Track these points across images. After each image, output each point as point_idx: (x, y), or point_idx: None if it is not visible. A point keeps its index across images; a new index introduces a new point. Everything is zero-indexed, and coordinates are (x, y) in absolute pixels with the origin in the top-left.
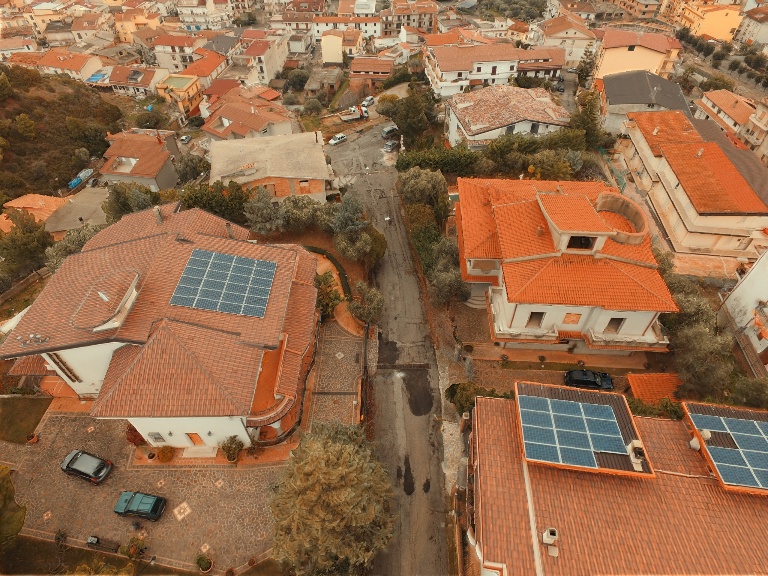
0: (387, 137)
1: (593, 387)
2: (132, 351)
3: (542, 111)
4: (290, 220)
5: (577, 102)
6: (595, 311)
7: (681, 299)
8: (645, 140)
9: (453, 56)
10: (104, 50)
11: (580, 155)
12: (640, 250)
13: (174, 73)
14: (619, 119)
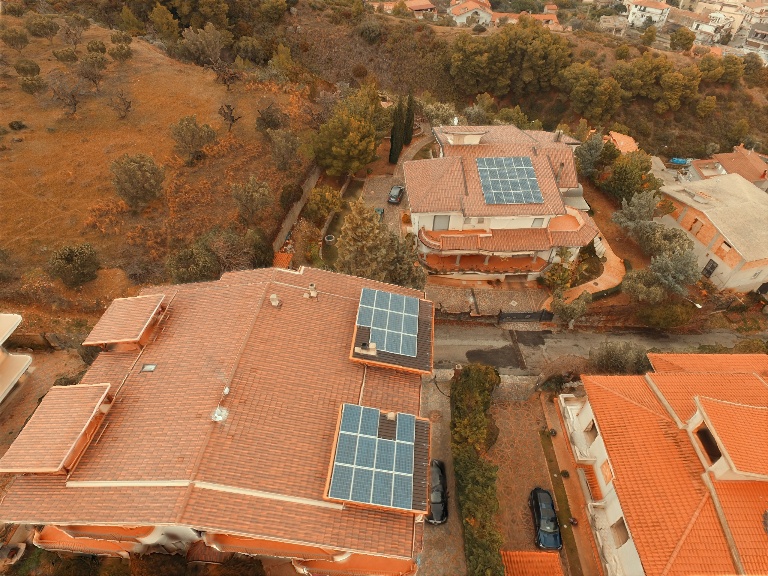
0: None
1: (536, 519)
2: None
3: None
4: (644, 235)
5: None
6: None
7: None
8: None
9: None
10: None
11: None
12: None
13: None
14: None
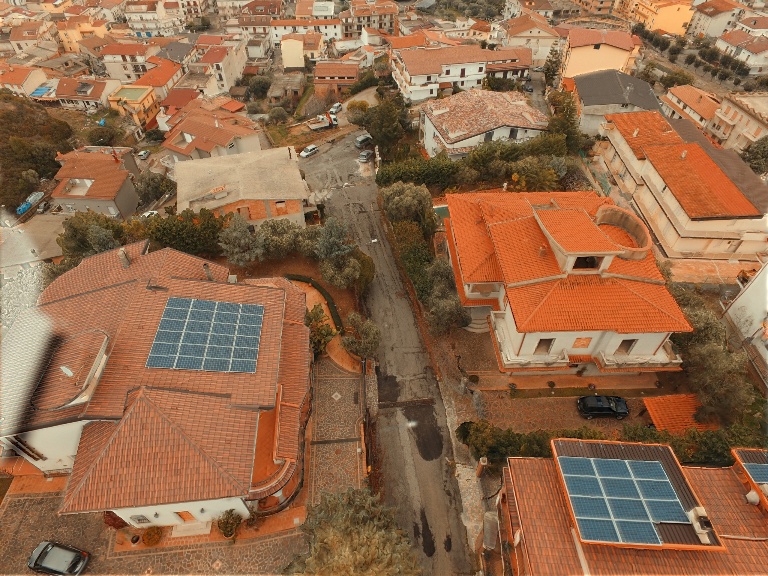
0: (361, 147)
1: (608, 413)
2: (106, 428)
3: (519, 115)
4: (270, 248)
5: (547, 102)
6: (607, 334)
7: (689, 313)
8: (626, 142)
9: (421, 59)
10: (48, 61)
11: (564, 161)
12: (645, 265)
13: (127, 84)
14: (594, 120)
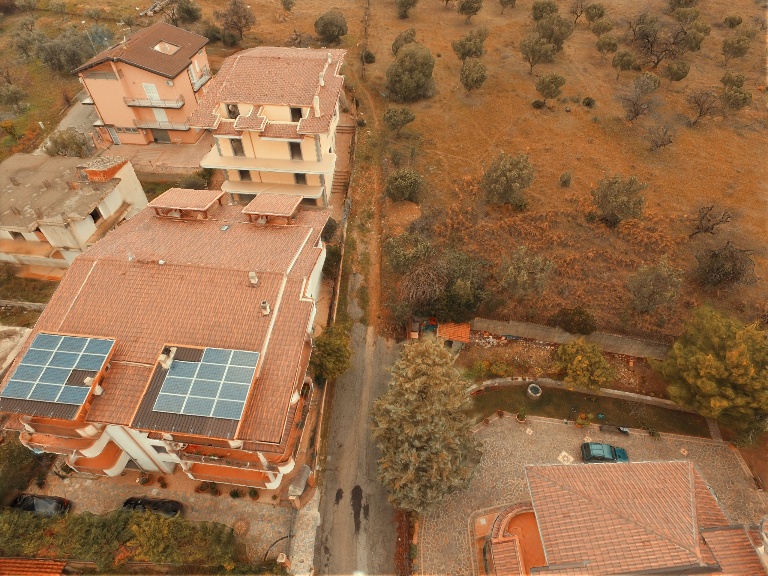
0: None
1: None
2: None
3: None
4: None
5: None
6: None
7: None
8: None
9: None
10: None
11: None
12: None
13: None
14: None
